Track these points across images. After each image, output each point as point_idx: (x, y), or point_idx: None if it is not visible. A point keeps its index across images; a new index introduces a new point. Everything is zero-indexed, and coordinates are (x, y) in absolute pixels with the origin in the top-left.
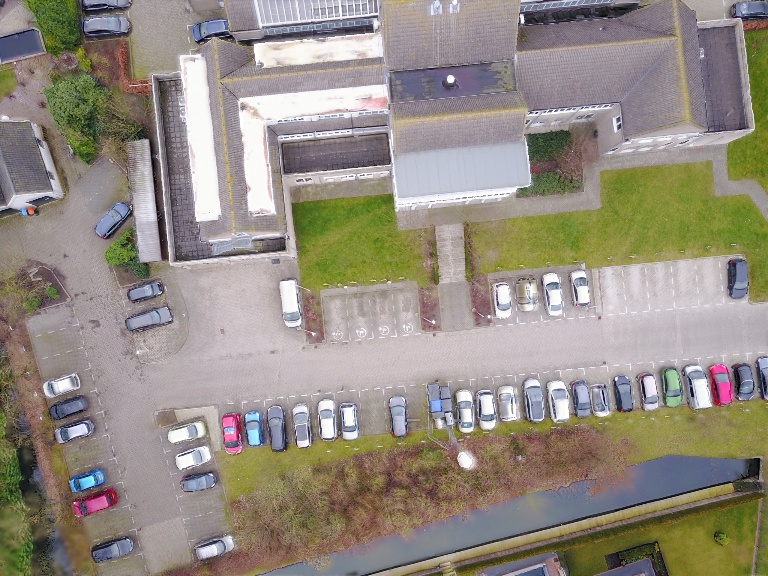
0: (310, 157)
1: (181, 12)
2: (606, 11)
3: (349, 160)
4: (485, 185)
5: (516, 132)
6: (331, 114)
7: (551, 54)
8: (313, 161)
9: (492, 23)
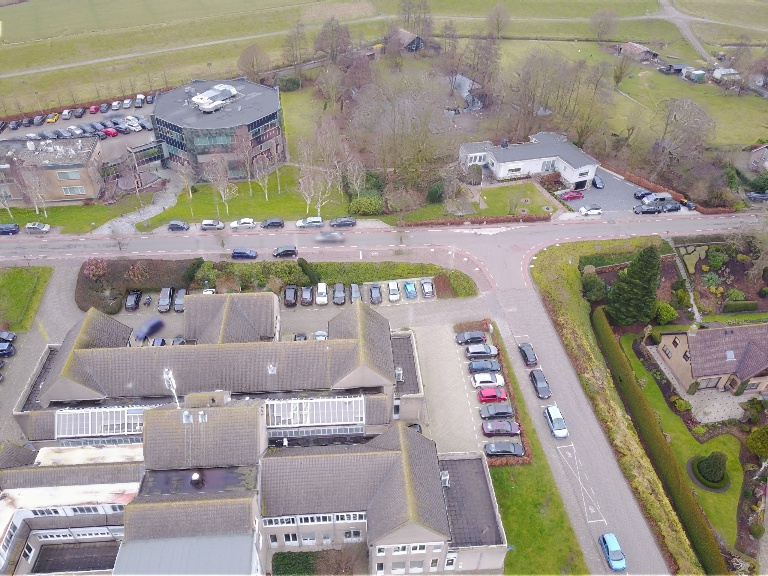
0: (64, 559)
1: (16, 439)
2: (360, 440)
3: (102, 564)
4: (204, 575)
5: (243, 523)
6: (81, 506)
7: (291, 461)
8: (65, 564)
9: (236, 432)
